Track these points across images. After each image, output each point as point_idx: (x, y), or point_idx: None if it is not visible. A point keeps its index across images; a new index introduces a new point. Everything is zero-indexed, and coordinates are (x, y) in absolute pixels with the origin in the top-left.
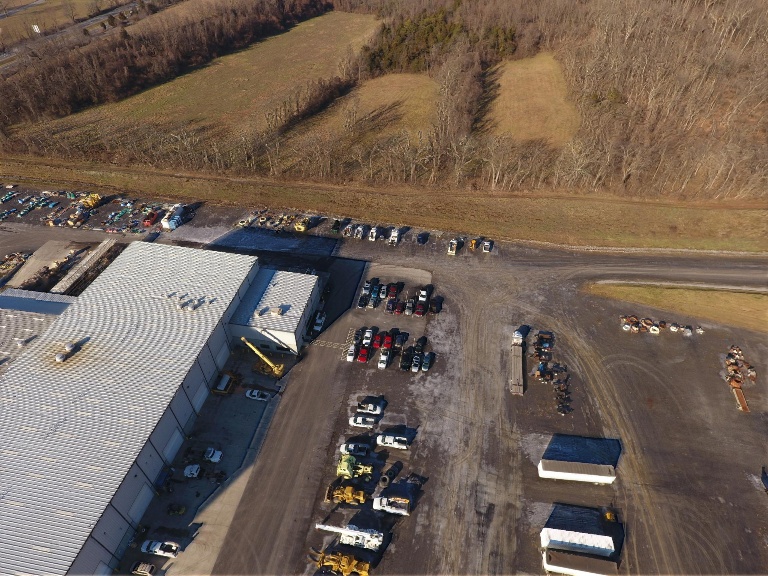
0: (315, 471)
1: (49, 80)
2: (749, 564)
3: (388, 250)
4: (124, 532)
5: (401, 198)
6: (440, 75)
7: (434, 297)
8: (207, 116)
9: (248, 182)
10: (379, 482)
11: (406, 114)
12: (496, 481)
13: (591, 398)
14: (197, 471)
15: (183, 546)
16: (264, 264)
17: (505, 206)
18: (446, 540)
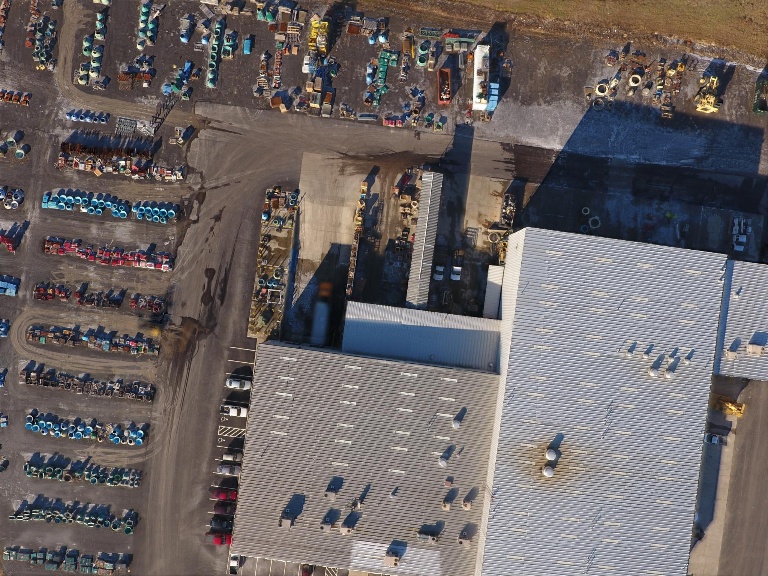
0: None
1: None
2: None
3: None
4: None
5: None
6: None
7: None
8: None
9: None
10: None
11: None
12: None
13: None
14: None
15: None
16: (663, 200)
17: None
18: None
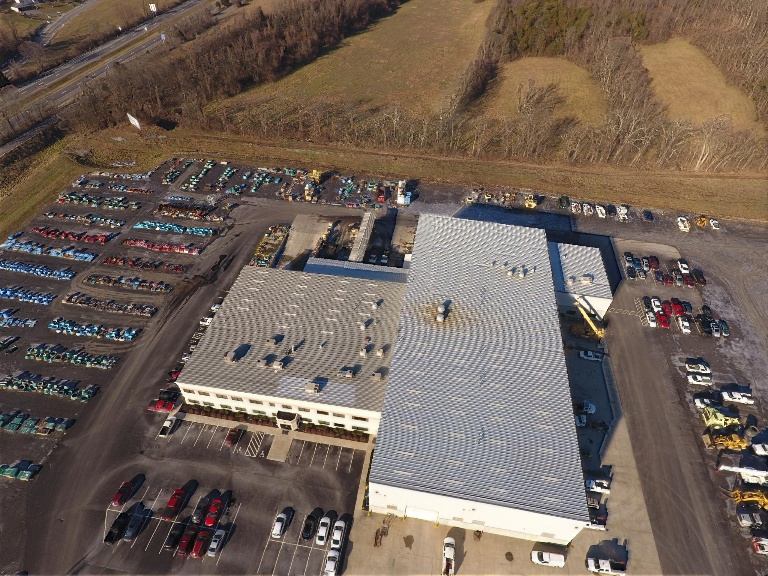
0: (682, 422)
1: None
2: None
3: (623, 226)
4: None
5: (611, 178)
6: (584, 59)
7: (692, 270)
8: (373, 97)
9: (454, 161)
10: (746, 432)
11: (568, 97)
12: None
13: None
14: None
15: None
16: None
17: (717, 186)
18: None
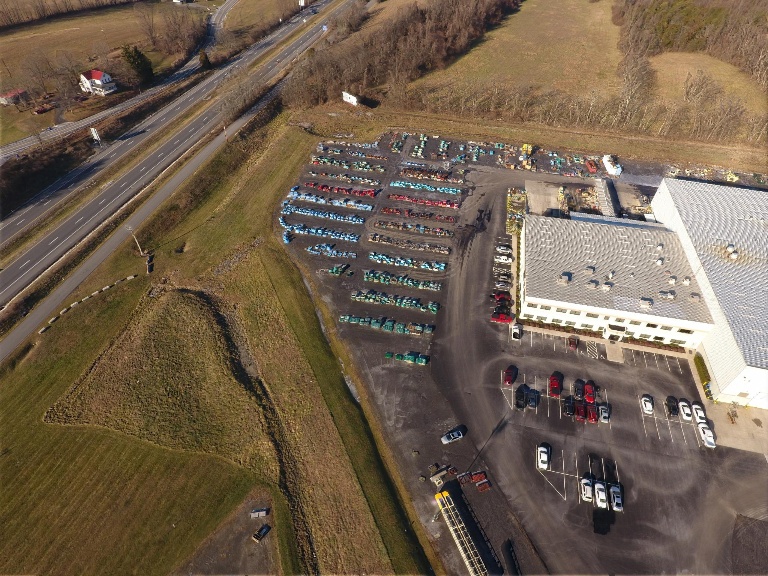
0: None
1: (395, 47)
2: None
3: None
4: None
5: None
6: (729, 54)
7: None
8: (540, 84)
9: (644, 140)
10: None
11: (725, 88)
12: None
13: None
14: None
15: None
16: None
17: None
18: None
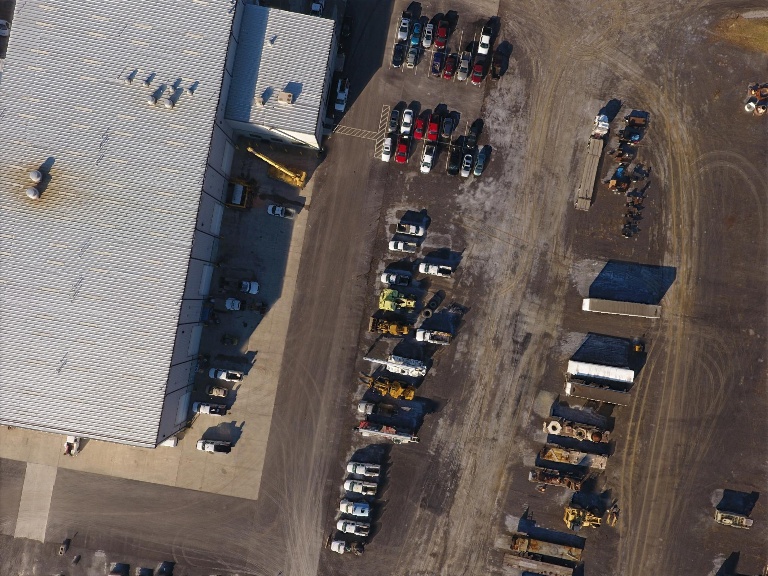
0: (357, 301)
1: None
2: (745, 388)
3: None
4: (189, 367)
5: None
6: None
7: (499, 44)
8: None
9: None
10: (421, 313)
11: None
12: (538, 311)
13: (665, 215)
14: (238, 306)
15: (245, 371)
16: None
17: None
18: (482, 365)
